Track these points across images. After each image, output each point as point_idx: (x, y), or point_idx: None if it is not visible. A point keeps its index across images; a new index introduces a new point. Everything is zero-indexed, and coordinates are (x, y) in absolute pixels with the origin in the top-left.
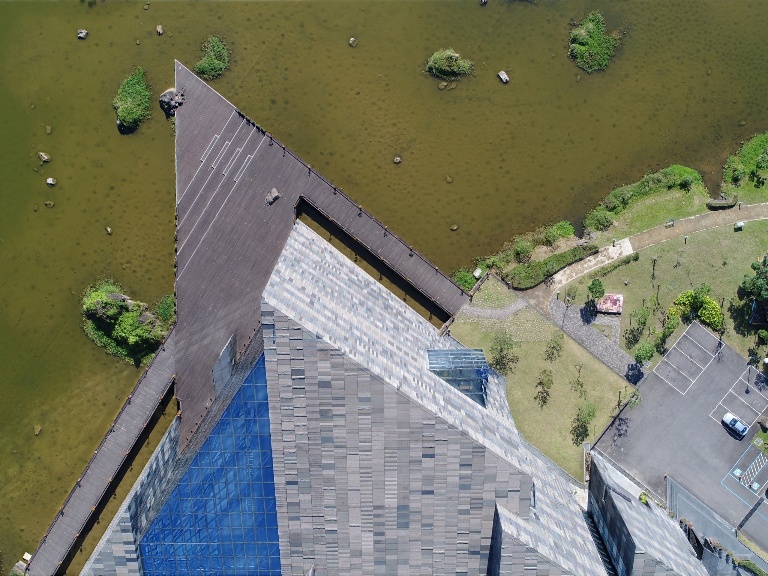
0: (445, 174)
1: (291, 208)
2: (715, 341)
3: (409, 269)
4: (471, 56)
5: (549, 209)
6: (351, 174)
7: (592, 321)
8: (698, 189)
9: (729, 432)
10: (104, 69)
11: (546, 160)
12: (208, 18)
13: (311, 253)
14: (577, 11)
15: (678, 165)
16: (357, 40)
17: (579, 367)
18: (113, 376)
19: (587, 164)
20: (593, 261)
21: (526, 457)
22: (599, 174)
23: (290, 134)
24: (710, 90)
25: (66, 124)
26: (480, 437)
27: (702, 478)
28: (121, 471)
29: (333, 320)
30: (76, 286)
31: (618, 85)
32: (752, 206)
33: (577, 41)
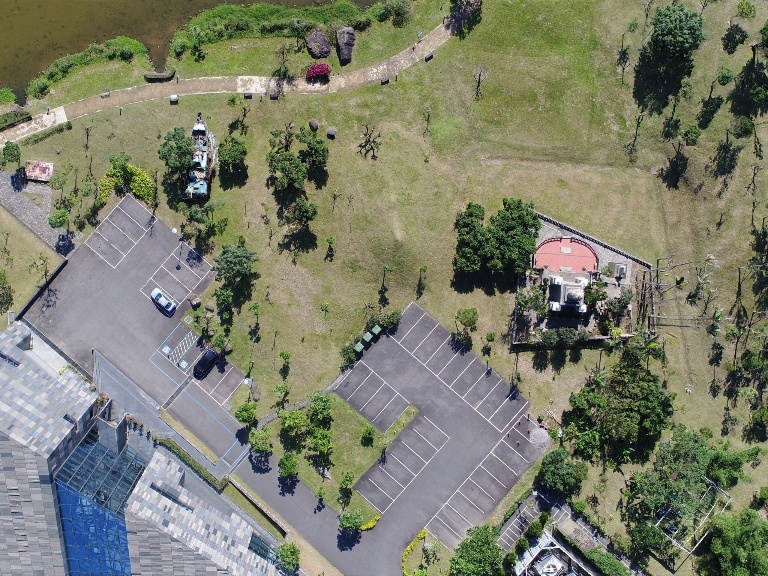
0: None
1: None
2: (148, 215)
3: None
4: None
5: None
6: None
7: (23, 189)
8: (140, 61)
9: (159, 308)
10: None
11: None
12: None
13: None
14: None
15: (124, 37)
16: None
17: (6, 234)
18: None
19: (33, 32)
20: (26, 128)
21: None
22: (45, 42)
23: None
24: None
25: None
26: None
27: (130, 354)
28: None
29: None
30: None
31: None
32: (190, 80)
33: None
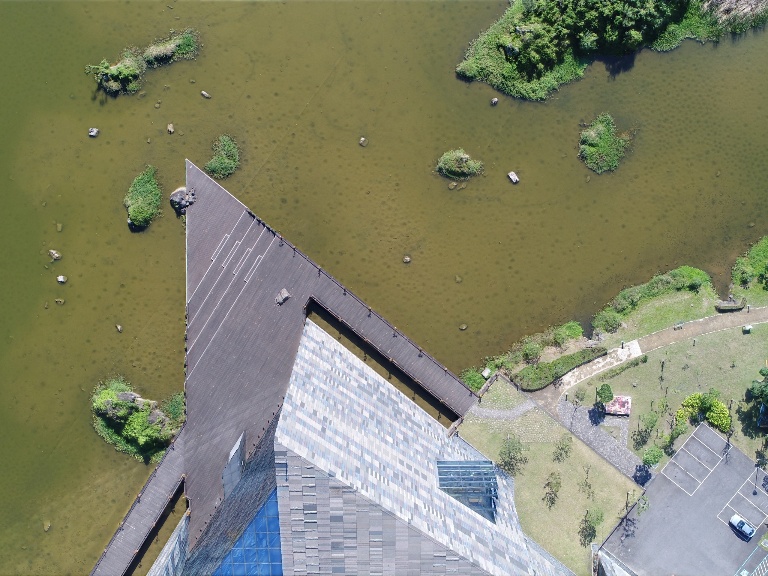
0: (454, 274)
1: (301, 308)
2: (723, 443)
3: (418, 370)
4: (481, 156)
5: (558, 309)
6: (361, 273)
7: (600, 422)
8: (707, 291)
9: (736, 533)
10: (115, 167)
11: (555, 260)
12: (219, 117)
13: (321, 361)
14: (587, 112)
15: (687, 266)
16: (367, 140)
17: (587, 468)
18: (122, 473)
19: (596, 264)
20: (602, 363)
21: (535, 570)
22: (608, 274)
23: (300, 233)
24: (719, 191)
25: (77, 222)
26: (490, 565)
27: None
28: (130, 568)
29: (345, 448)
30: (86, 383)
31: (627, 186)
32: (761, 309)
33: (587, 142)
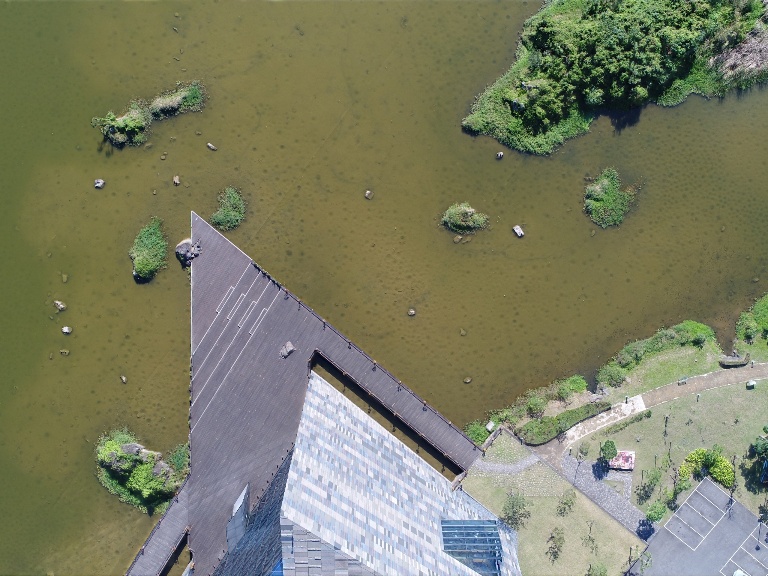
0: (459, 327)
1: (306, 362)
2: (726, 498)
3: (422, 423)
4: (486, 210)
5: (562, 363)
6: (365, 326)
7: (604, 477)
8: (711, 346)
9: None
10: (121, 218)
11: (560, 314)
12: (225, 169)
13: (326, 418)
14: (592, 166)
15: (691, 321)
16: (373, 193)
17: (590, 523)
18: (126, 524)
19: (600, 318)
20: (606, 417)
21: None
22: (612, 329)
23: (305, 285)
24: (724, 246)
25: (82, 273)
26: None
27: None
28: None
29: (350, 515)
30: (90, 434)
31: (632, 240)
32: (764, 364)
33: (592, 197)
